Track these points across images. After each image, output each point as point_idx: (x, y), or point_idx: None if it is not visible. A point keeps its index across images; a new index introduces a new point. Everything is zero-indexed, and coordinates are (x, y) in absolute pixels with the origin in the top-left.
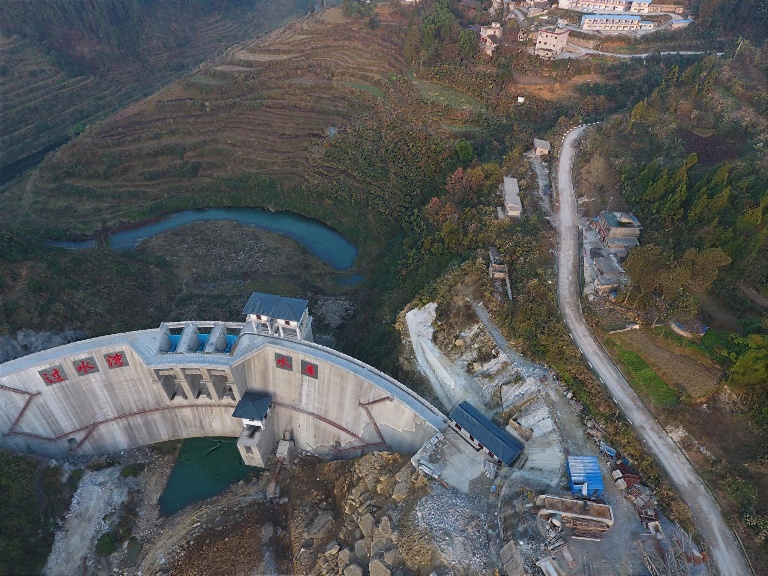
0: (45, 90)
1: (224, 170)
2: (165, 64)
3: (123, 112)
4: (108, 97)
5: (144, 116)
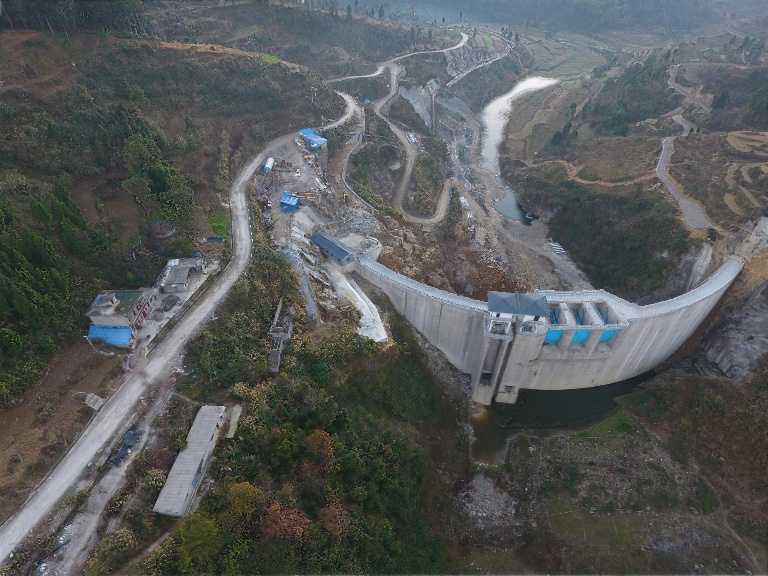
0: None
1: None
2: None
3: None
4: None
5: None
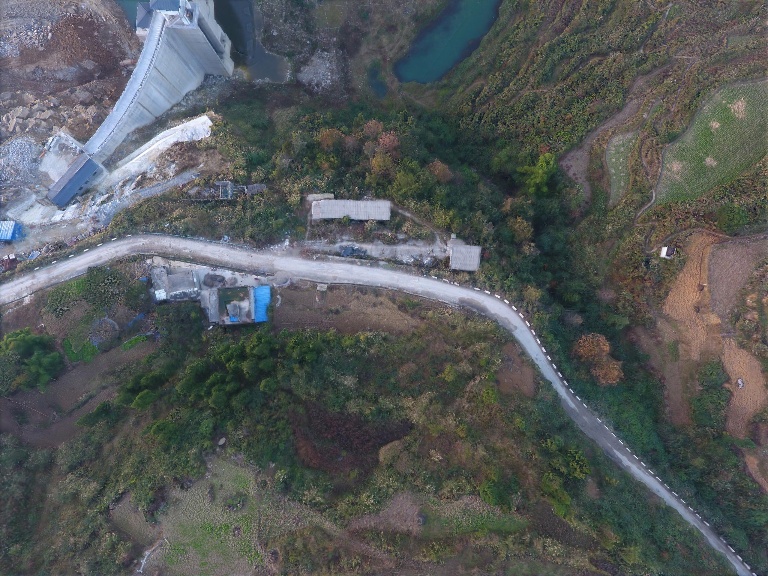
0: None
1: None
2: None
3: None
4: None
5: None
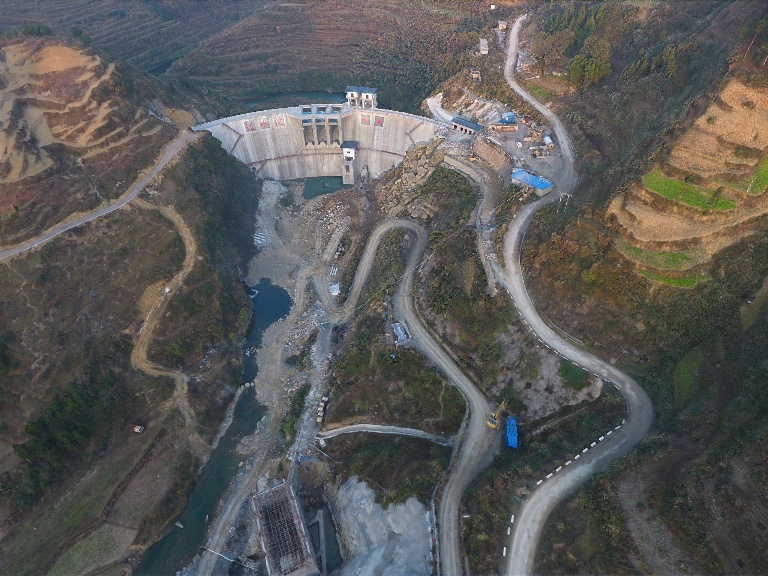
0: (151, 28)
1: (294, 69)
2: (226, 14)
3: (221, 34)
4: (192, 35)
5: (236, 36)
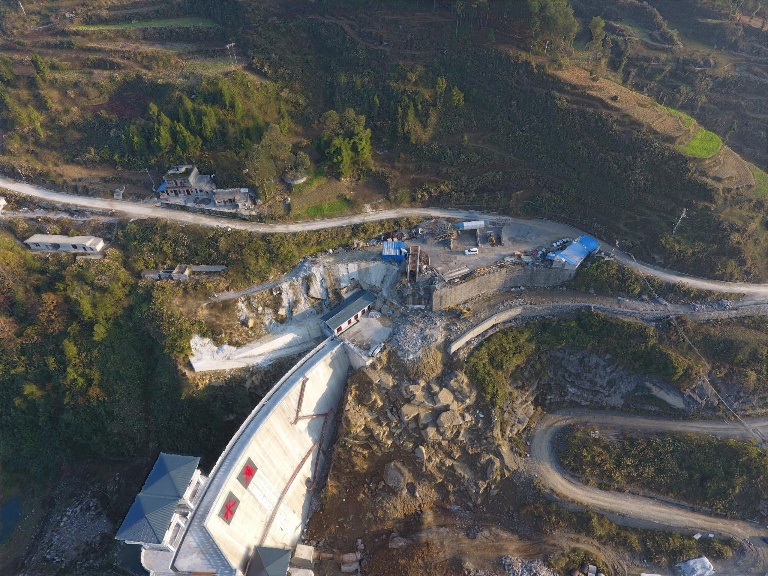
0: None
1: None
2: None
3: None
4: None
5: None
